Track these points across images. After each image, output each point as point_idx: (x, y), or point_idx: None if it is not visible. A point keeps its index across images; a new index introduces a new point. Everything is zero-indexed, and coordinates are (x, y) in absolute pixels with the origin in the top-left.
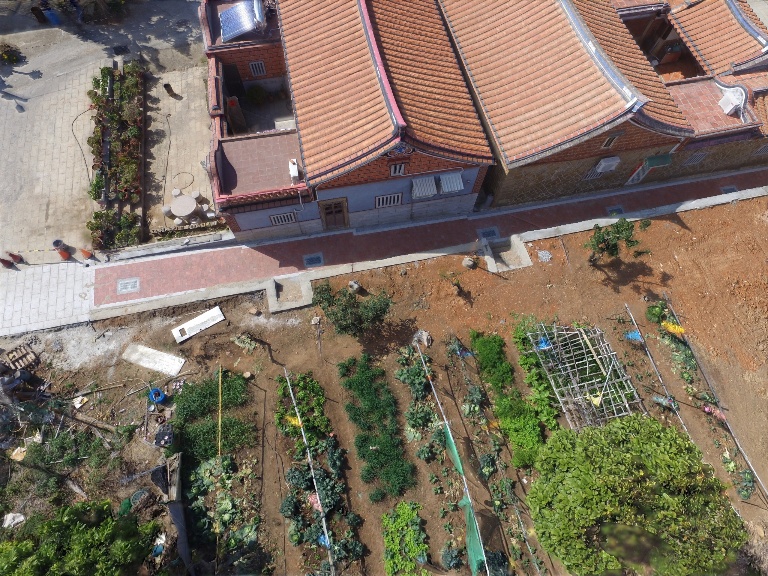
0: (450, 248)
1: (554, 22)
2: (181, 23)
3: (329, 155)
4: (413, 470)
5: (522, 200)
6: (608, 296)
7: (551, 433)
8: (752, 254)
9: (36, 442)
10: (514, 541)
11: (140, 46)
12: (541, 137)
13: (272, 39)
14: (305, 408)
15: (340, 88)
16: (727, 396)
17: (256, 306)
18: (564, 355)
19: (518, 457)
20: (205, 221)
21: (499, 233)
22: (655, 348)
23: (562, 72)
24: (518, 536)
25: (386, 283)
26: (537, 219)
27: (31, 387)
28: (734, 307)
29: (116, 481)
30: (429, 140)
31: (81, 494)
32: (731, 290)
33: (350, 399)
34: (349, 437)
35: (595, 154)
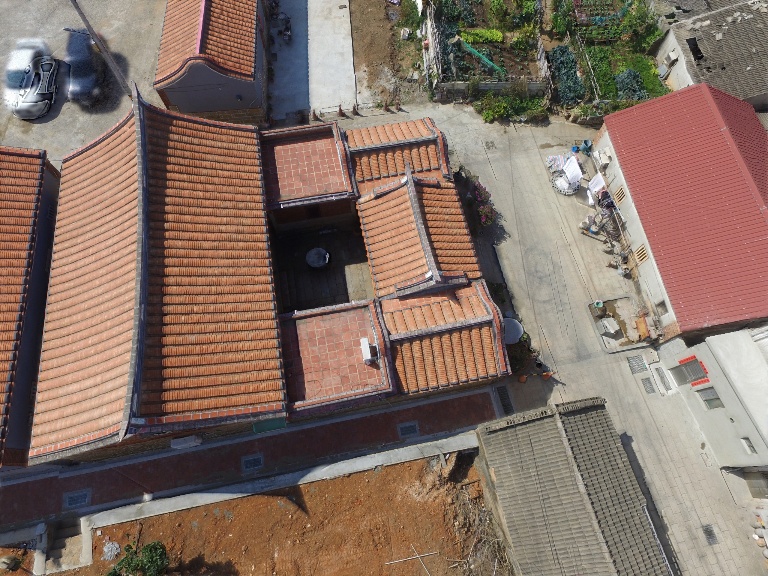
0: None
1: (130, 258)
2: None
3: None
4: None
5: (128, 453)
6: None
7: None
8: (375, 551)
9: None
10: None
11: None
12: (69, 427)
13: None
14: None
15: None
16: None
17: None
18: None
19: None
20: None
21: (91, 498)
22: None
23: (115, 334)
24: None
25: None
26: (147, 476)
27: None
28: None
29: None
30: None
31: None
32: None
33: None
34: None
35: (158, 436)
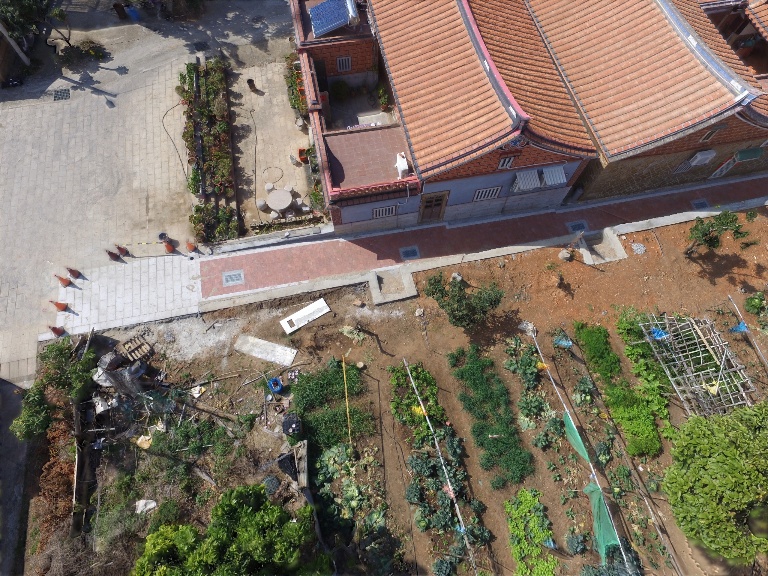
0: (545, 241)
1: (648, 17)
2: (256, 19)
3: (440, 148)
4: (531, 458)
5: (609, 194)
6: (705, 288)
7: (662, 422)
8: None
9: (160, 431)
10: (636, 527)
11: (219, 42)
12: (642, 130)
13: (363, 34)
14: (420, 397)
15: (445, 82)
16: None
17: (359, 298)
18: (677, 345)
19: (635, 445)
20: (298, 215)
21: (588, 226)
22: (756, 339)
23: (660, 66)
24: (639, 522)
25: (486, 275)
26: (624, 212)
27: (148, 377)
28: None
29: (243, 468)
30: (543, 133)
31: (210, 481)
32: None
33: (462, 389)
34: (464, 426)
35: (692, 147)
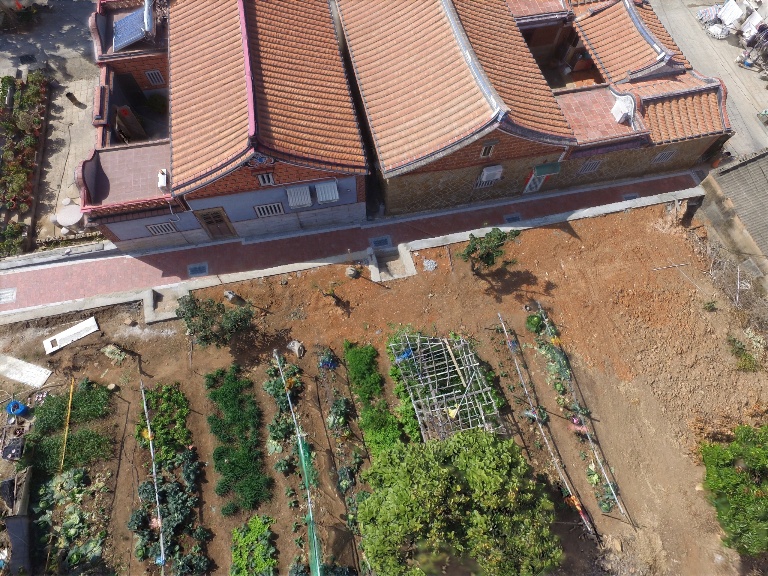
0: (334, 257)
1: (439, 31)
2: None
3: (195, 165)
4: (270, 483)
5: (416, 209)
6: (489, 306)
7: None
8: (640, 263)
9: None
10: None
11: (48, 55)
12: (417, 146)
13: (164, 48)
14: (166, 420)
15: (214, 98)
16: (600, 407)
17: (133, 316)
18: (425, 366)
19: None
20: (95, 230)
21: (391, 242)
22: (532, 358)
23: (442, 81)
24: None
25: (265, 293)
26: (432, 228)
27: None
28: (616, 316)
29: None
30: (291, 150)
31: None
32: (614, 299)
33: (214, 411)
34: (209, 450)
35: (476, 163)
